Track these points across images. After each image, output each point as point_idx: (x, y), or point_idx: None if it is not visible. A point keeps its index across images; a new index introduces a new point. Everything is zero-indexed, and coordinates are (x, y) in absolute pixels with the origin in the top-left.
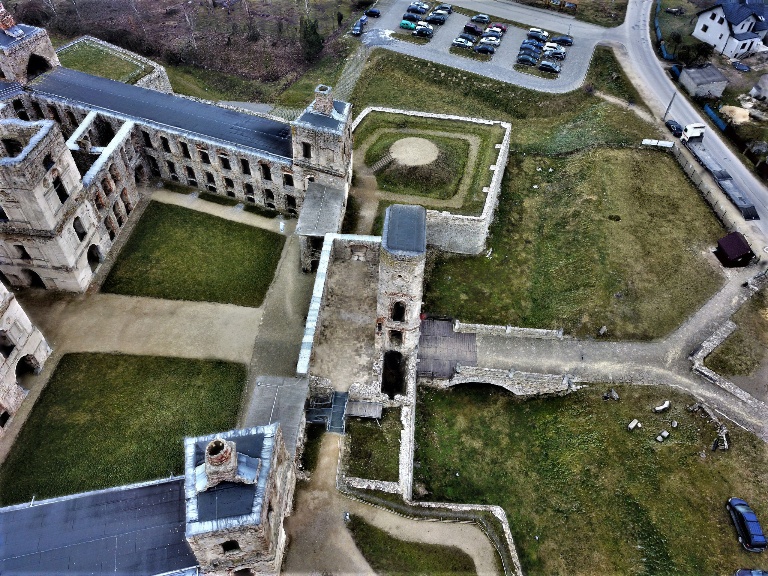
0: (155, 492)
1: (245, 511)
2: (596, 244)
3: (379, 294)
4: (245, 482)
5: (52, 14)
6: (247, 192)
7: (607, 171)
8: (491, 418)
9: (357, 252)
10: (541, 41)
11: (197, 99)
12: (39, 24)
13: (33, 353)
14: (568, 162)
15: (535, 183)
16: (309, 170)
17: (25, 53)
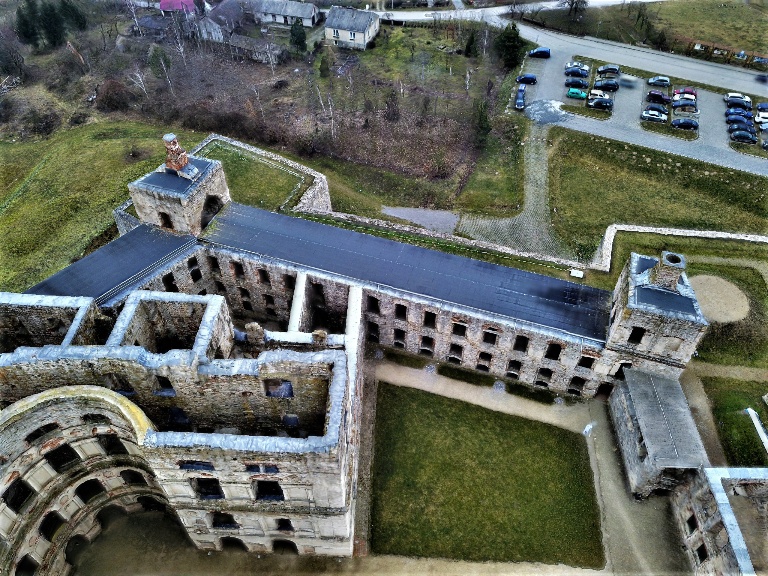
0: None
1: None
2: None
3: None
4: None
5: (139, 93)
6: (508, 367)
7: None
8: None
9: None
10: (746, 109)
11: (389, 224)
12: (126, 107)
13: None
14: None
15: None
16: (629, 356)
17: (201, 197)
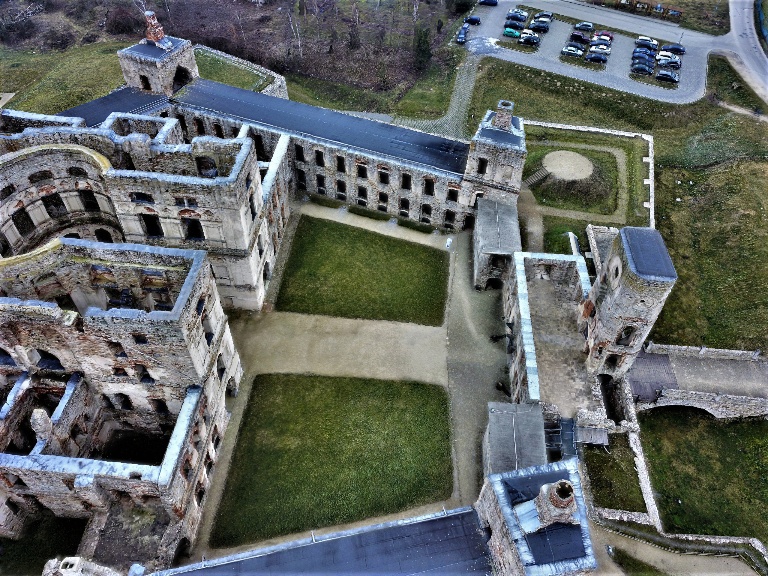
0: (438, 527)
1: (580, 553)
2: (767, 261)
3: (609, 318)
4: (573, 523)
5: (143, 21)
6: (401, 206)
7: (757, 185)
8: (697, 442)
9: (537, 270)
10: (651, 50)
11: None
12: (130, 31)
13: (234, 375)
14: (709, 175)
15: (677, 196)
16: (480, 186)
17: (173, 65)
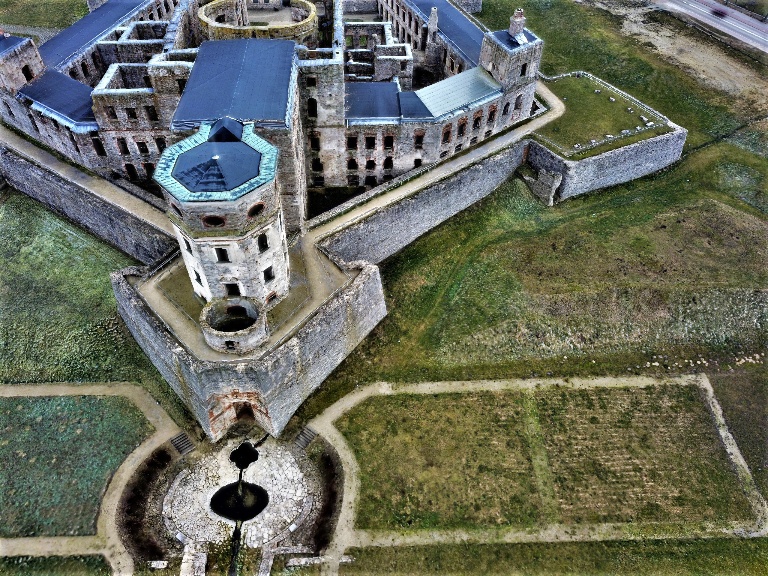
0: None
1: None
2: None
3: None
4: None
5: None
6: None
7: None
8: None
9: None
10: None
11: None
12: None
13: None
14: None
15: None
16: None
17: None
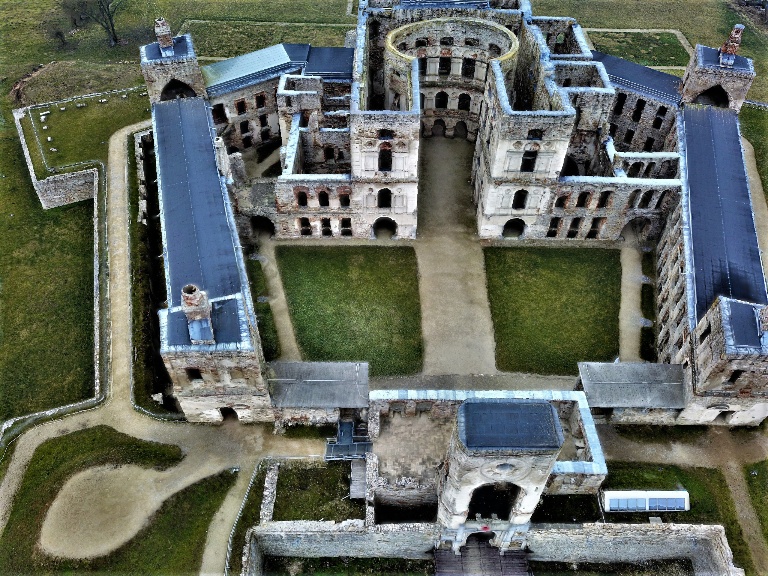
0: None
1: (170, 340)
2: None
3: None
4: None
5: None
6: None
7: None
8: None
9: None
10: None
11: None
12: None
13: (399, 224)
14: None
15: None
16: None
17: (713, 80)
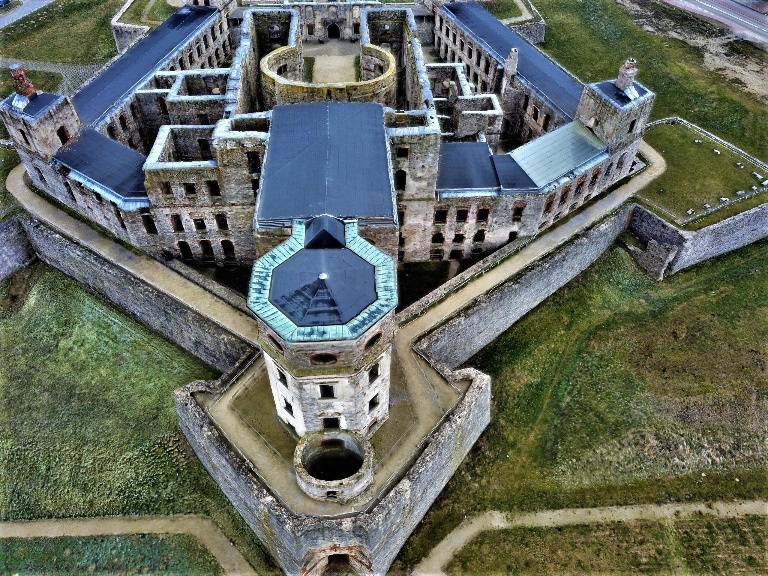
0: (453, 10)
1: None
2: None
3: None
4: None
5: None
6: None
7: None
8: None
9: None
10: None
11: None
12: None
13: None
14: None
15: None
16: None
17: None
